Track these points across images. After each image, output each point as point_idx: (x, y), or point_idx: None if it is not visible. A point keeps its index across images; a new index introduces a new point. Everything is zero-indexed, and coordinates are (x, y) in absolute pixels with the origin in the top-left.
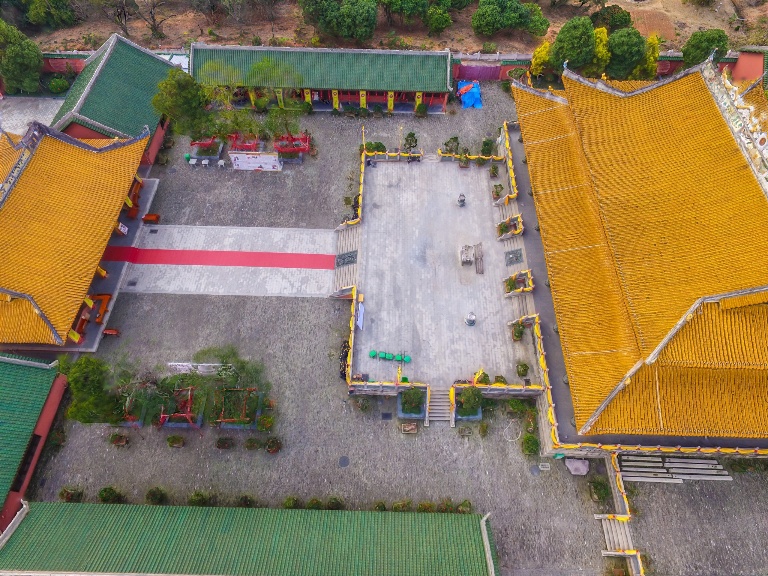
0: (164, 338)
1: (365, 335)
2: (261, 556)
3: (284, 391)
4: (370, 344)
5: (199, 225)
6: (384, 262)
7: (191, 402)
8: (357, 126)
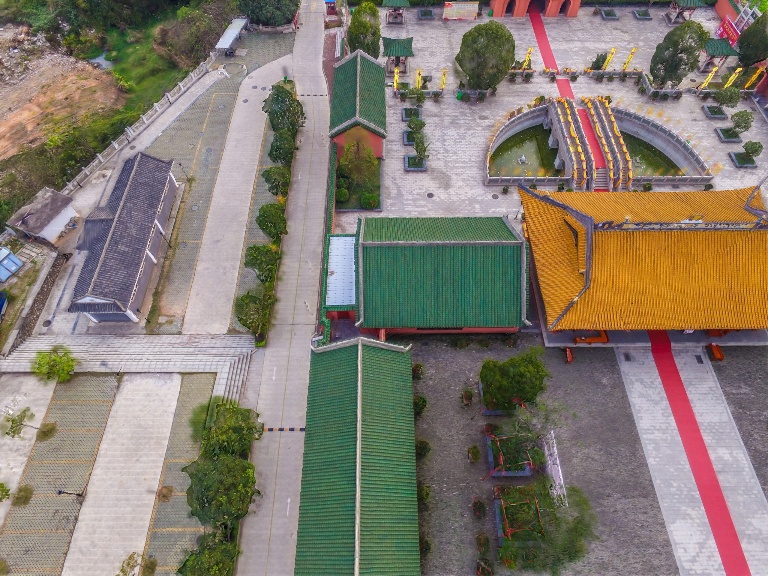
0: (576, 409)
1: None
2: None
3: (549, 573)
4: None
5: (731, 410)
6: None
7: None
8: None
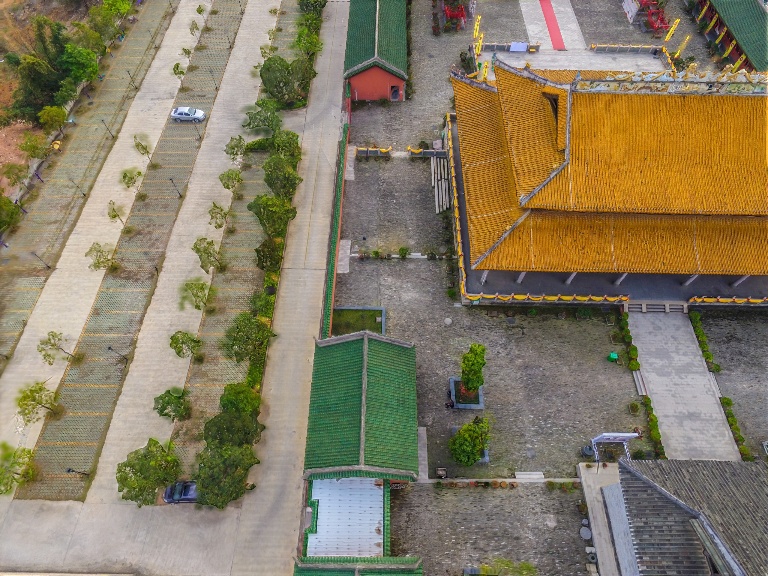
0: None
1: (507, 55)
2: (386, 3)
3: (467, 35)
4: (501, 57)
5: None
6: (565, 62)
7: (455, 4)
8: (700, 57)
